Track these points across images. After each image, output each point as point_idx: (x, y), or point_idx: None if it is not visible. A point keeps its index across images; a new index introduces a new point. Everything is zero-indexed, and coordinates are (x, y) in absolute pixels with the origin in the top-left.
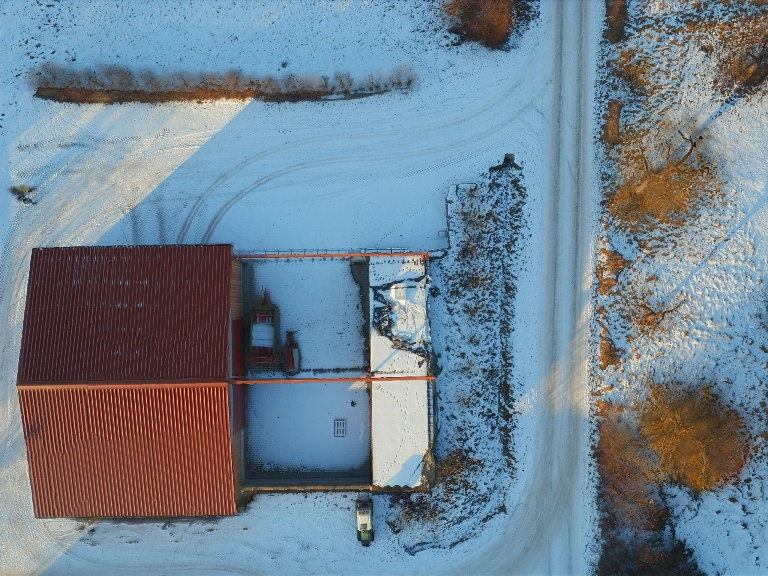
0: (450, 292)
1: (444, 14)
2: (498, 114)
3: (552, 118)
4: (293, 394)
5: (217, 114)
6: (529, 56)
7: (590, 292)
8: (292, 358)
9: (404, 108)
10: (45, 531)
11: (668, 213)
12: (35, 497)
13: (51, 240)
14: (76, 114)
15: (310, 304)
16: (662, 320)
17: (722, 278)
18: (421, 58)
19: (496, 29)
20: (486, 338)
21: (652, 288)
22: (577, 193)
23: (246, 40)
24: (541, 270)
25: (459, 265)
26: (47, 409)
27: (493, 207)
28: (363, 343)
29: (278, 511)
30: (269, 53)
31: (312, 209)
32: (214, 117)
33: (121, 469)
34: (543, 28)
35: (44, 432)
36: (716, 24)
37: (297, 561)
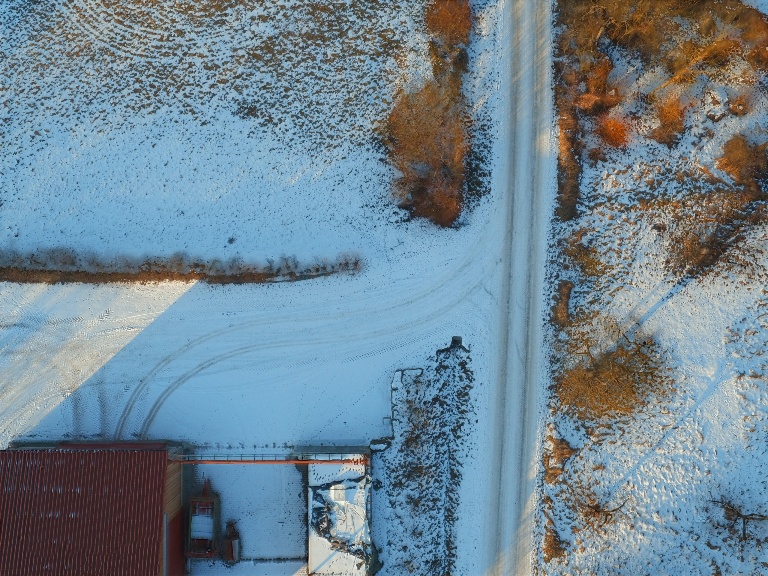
0: (392, 485)
1: (394, 189)
2: (446, 295)
3: (501, 299)
4: None
5: (160, 295)
6: (479, 234)
7: (536, 481)
8: (231, 550)
9: (350, 290)
10: None
11: (616, 399)
12: None
13: None
14: (17, 294)
15: (251, 492)
16: (608, 512)
17: (669, 468)
18: (370, 235)
19: (445, 211)
20: (429, 528)
21: (598, 478)
22: (525, 377)
23: (192, 215)
24: (487, 457)
25: (402, 456)
26: None
27: (439, 391)
28: (304, 533)
29: None
30: (215, 228)
31: (255, 394)
32: (157, 299)
33: None
34: (494, 205)
35: None
36: (669, 202)
37: None
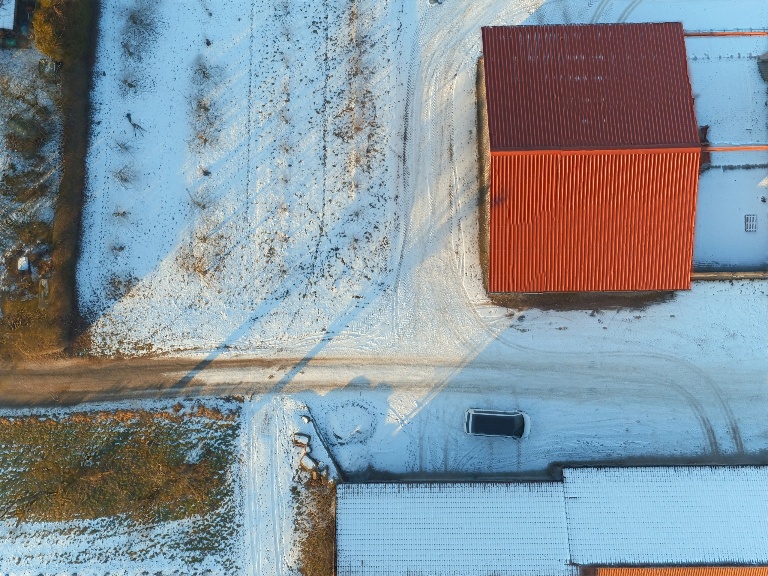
0: None
1: None
2: None
3: None
4: (703, 190)
5: None
6: None
7: None
8: None
9: None
10: (475, 317)
11: None
12: (492, 270)
13: (458, 39)
14: None
15: (718, 101)
16: None
17: None
18: None
19: None
20: None
21: None
22: None
23: None
24: None
25: None
26: (517, 176)
27: None
28: None
29: (705, 298)
30: None
31: (717, 8)
32: None
33: (582, 240)
34: None
35: (511, 201)
36: None
37: (723, 348)
